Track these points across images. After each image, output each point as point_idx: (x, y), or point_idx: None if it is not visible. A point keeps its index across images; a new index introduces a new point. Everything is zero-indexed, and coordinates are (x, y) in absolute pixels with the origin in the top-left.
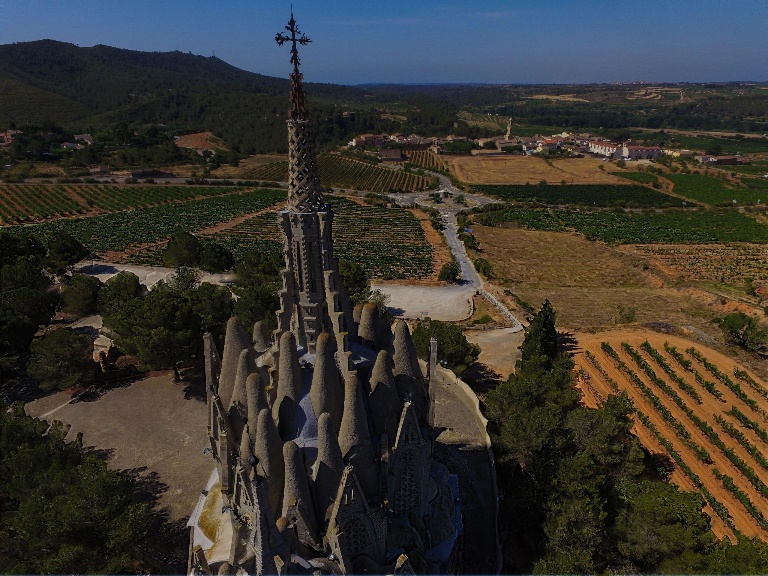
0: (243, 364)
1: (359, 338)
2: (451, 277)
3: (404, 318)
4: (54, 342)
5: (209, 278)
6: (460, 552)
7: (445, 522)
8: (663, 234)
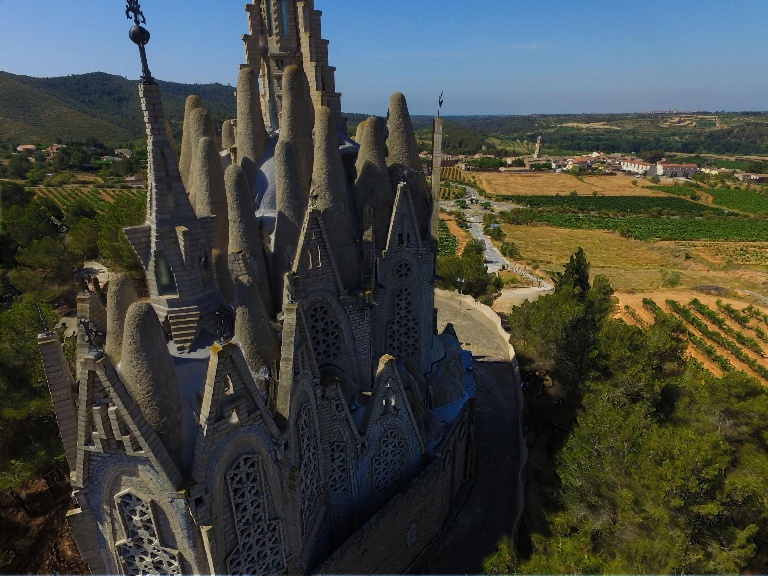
0: None
1: None
2: None
3: None
4: (41, 253)
5: None
6: (472, 426)
7: (452, 379)
8: (704, 235)
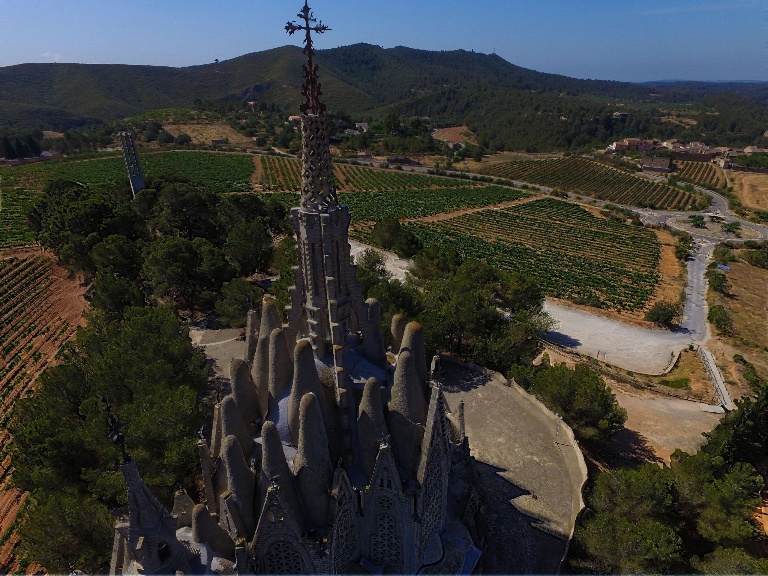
0: (259, 348)
1: (380, 357)
2: (662, 319)
3: (575, 351)
4: None
5: (392, 262)
6: None
7: None
8: None
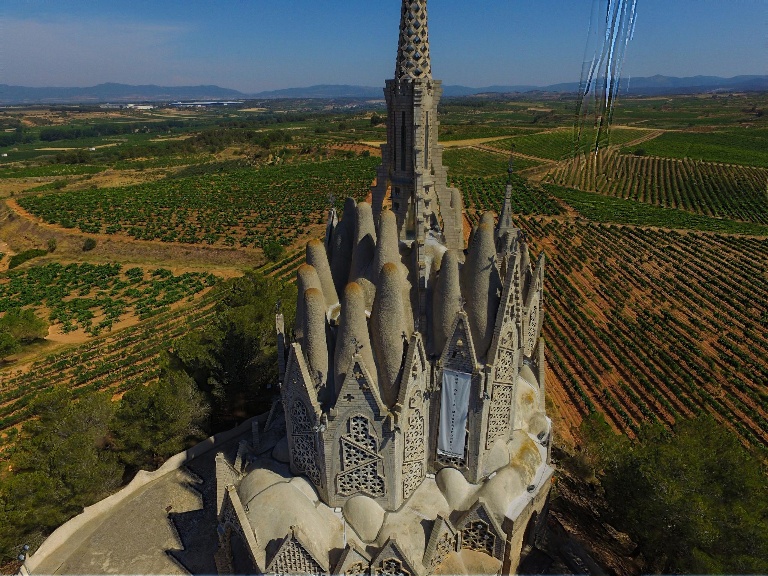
0: None
1: None
2: None
3: None
4: None
5: None
6: None
7: None
8: None
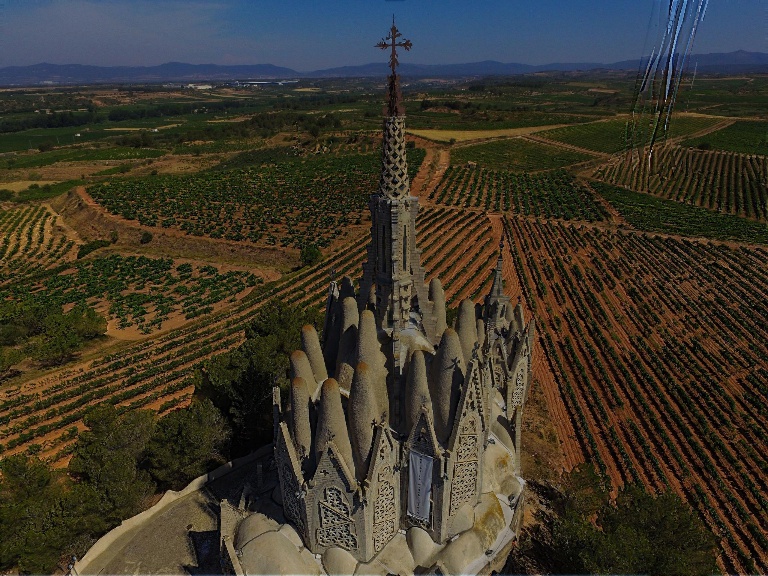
0: None
1: None
2: None
3: None
4: None
5: None
6: None
7: None
8: None
